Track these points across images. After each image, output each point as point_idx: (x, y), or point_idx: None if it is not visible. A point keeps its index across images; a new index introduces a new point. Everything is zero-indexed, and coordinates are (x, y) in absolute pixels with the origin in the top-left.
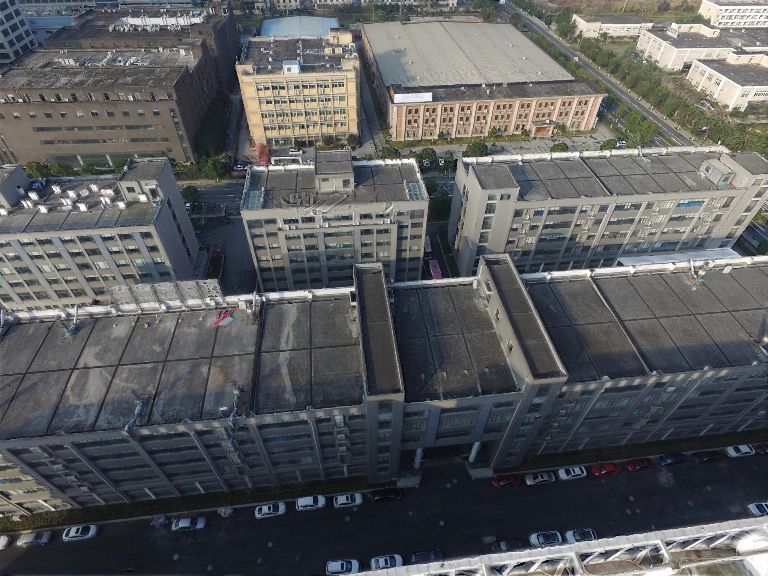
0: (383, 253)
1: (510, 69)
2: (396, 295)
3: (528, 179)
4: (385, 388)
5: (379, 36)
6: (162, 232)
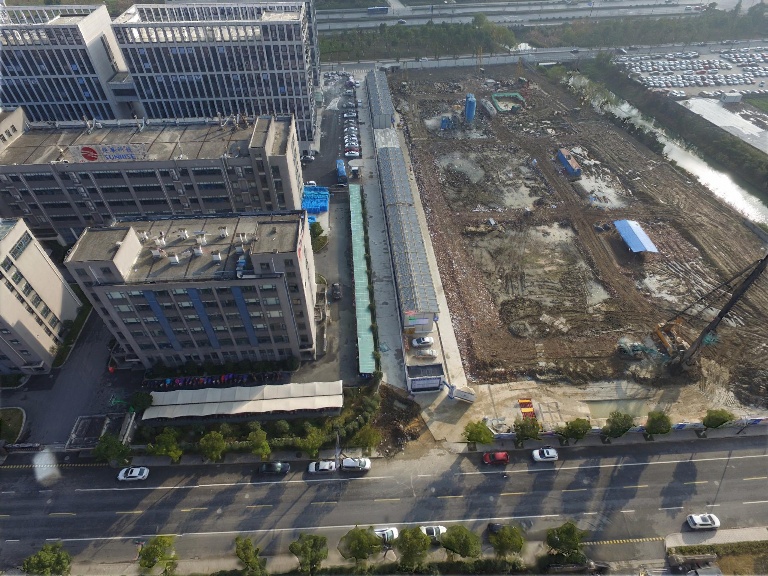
0: None
1: None
2: None
3: None
4: (9, 112)
5: None
6: None
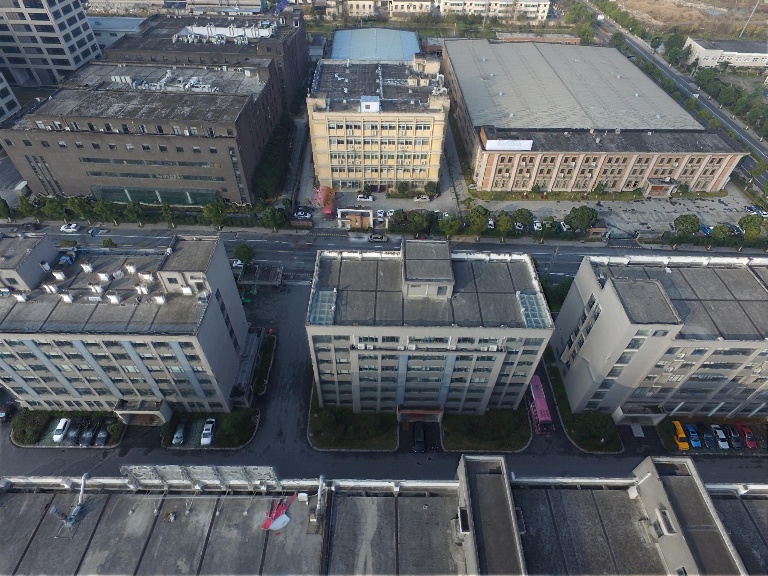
0: (479, 379)
1: (621, 109)
2: (517, 498)
3: (682, 297)
4: None
5: (464, 57)
6: (206, 338)
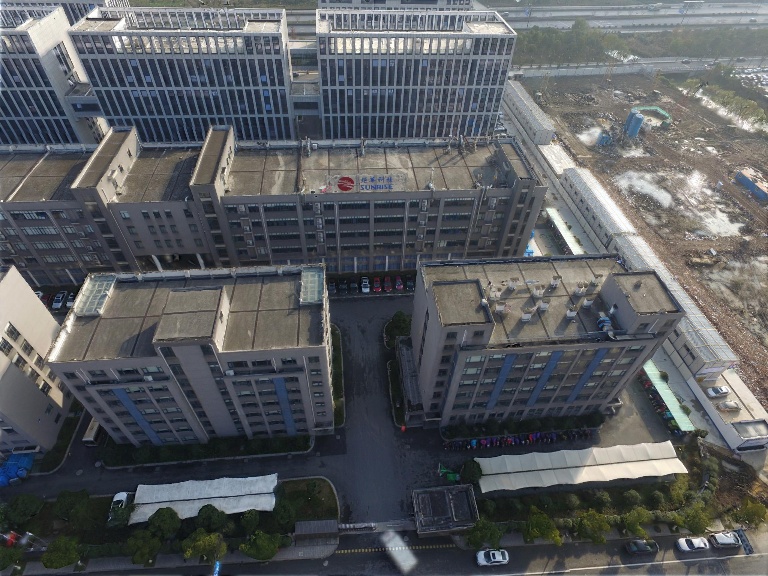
0: None
1: None
2: None
3: None
4: (221, 131)
5: None
6: None
